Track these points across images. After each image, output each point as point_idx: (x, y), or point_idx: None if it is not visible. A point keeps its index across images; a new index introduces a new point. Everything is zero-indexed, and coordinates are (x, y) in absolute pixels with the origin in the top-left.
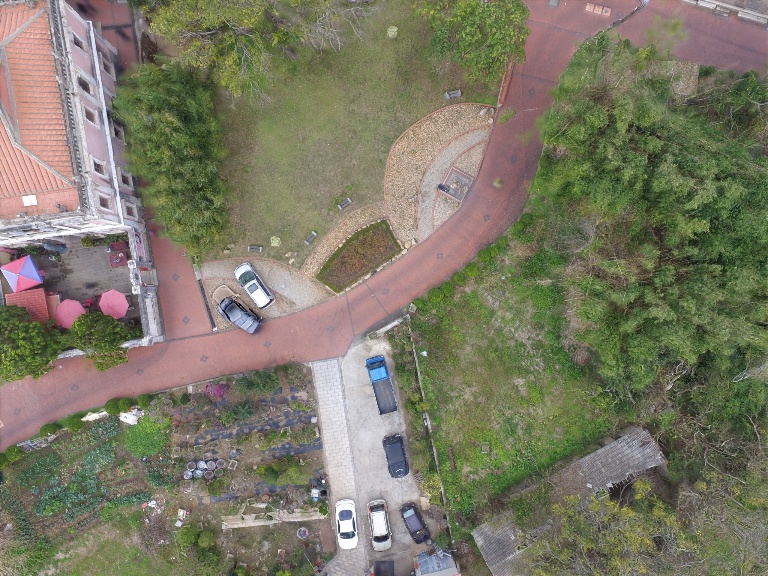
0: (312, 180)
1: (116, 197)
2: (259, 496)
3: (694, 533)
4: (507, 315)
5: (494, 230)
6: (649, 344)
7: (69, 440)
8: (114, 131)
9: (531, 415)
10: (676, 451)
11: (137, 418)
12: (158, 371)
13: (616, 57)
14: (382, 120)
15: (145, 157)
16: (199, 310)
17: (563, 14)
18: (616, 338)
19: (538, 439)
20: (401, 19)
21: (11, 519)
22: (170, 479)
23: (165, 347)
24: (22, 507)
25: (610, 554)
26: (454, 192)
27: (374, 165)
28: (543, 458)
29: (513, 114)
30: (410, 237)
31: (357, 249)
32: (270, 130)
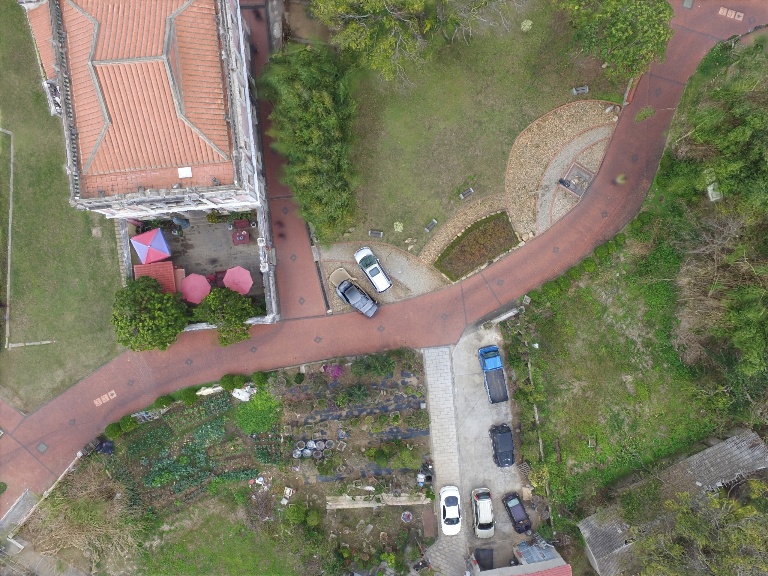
0: (435, 168)
1: (254, 174)
2: (365, 478)
3: None
4: (619, 312)
5: (611, 227)
6: None
7: (181, 413)
8: None
9: (637, 412)
10: None
11: (249, 395)
12: (272, 350)
13: (753, 61)
14: (508, 112)
15: (294, 136)
16: (315, 291)
17: (696, 17)
18: (762, 337)
19: (643, 436)
20: (533, 14)
21: (120, 488)
22: (278, 457)
23: (280, 326)
24: (131, 477)
25: (725, 551)
26: (574, 187)
27: (497, 157)
28: (647, 455)
29: (653, 112)
30: (528, 230)
31: (477, 239)
32: (397, 117)
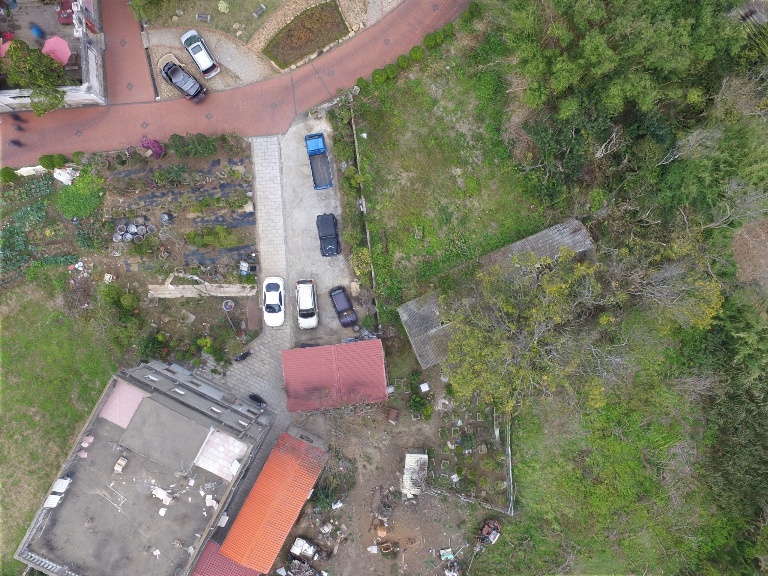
0: None
1: None
2: (188, 267)
3: (612, 289)
4: (449, 105)
5: (442, 20)
6: (571, 68)
7: (1, 195)
8: None
9: (467, 207)
10: None
11: (71, 178)
12: (97, 134)
13: None
14: None
15: None
16: (144, 78)
17: None
18: (539, 60)
19: (473, 231)
20: None
21: None
22: None
23: (106, 111)
24: None
25: (530, 317)
26: None
27: None
28: None
29: None
30: (358, 20)
31: (304, 23)
32: None
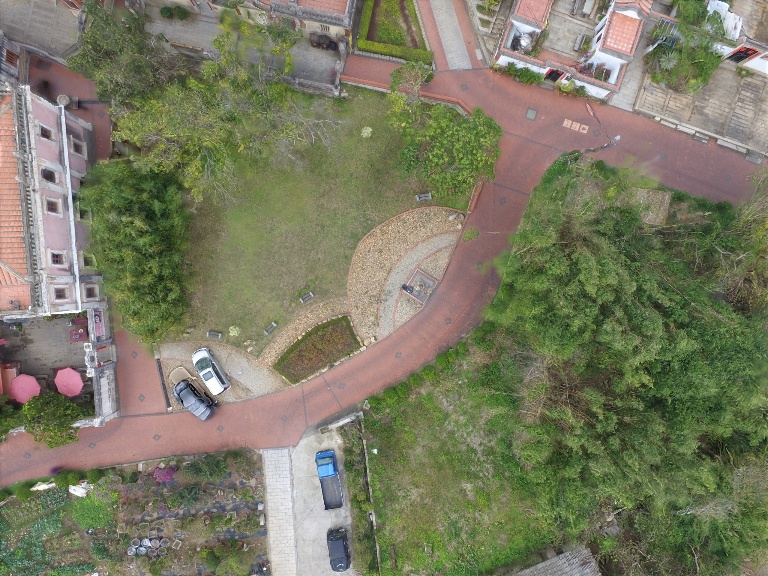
0: (276, 271)
1: (75, 283)
2: None
3: None
4: (461, 419)
5: (455, 334)
6: (585, 492)
7: (18, 506)
8: (79, 214)
9: (477, 520)
10: (615, 575)
11: (86, 491)
12: (110, 446)
13: (586, 182)
14: (351, 217)
15: (103, 254)
16: (155, 389)
17: (540, 128)
18: (552, 484)
19: (482, 544)
20: (377, 118)
21: None
22: (114, 553)
23: (119, 423)
24: None
25: None
26: (417, 293)
27: (339, 261)
28: (485, 563)
29: (476, 235)
30: (370, 334)
31: (315, 344)
32: (238, 218)
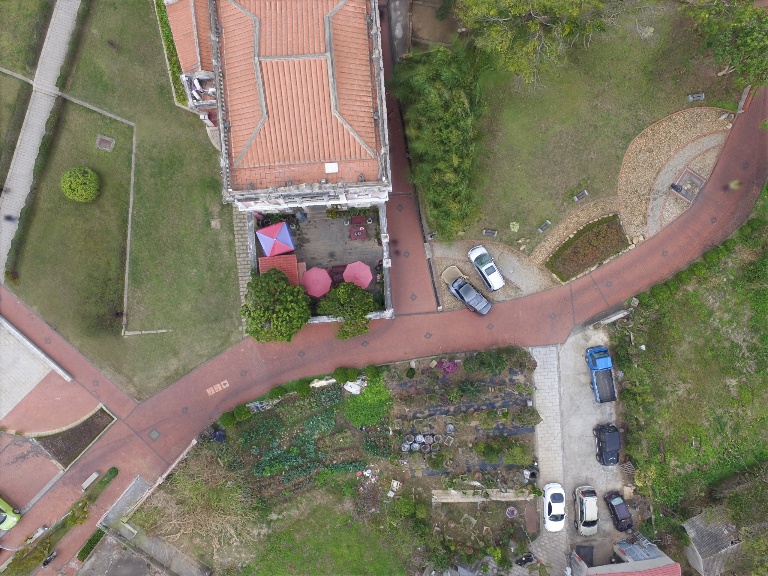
0: (550, 170)
1: None
2: (470, 473)
3: None
4: (725, 316)
5: (720, 232)
6: None
7: (292, 404)
8: None
9: (739, 415)
10: None
11: (360, 388)
12: (383, 344)
13: None
14: (623, 117)
15: (433, 135)
16: (426, 288)
17: None
18: None
19: (744, 439)
20: (652, 21)
21: (231, 477)
22: (386, 450)
23: (391, 321)
24: (242, 466)
25: None
26: (685, 193)
27: (611, 160)
28: (748, 458)
29: None
30: (638, 233)
31: (590, 240)
32: (514, 118)
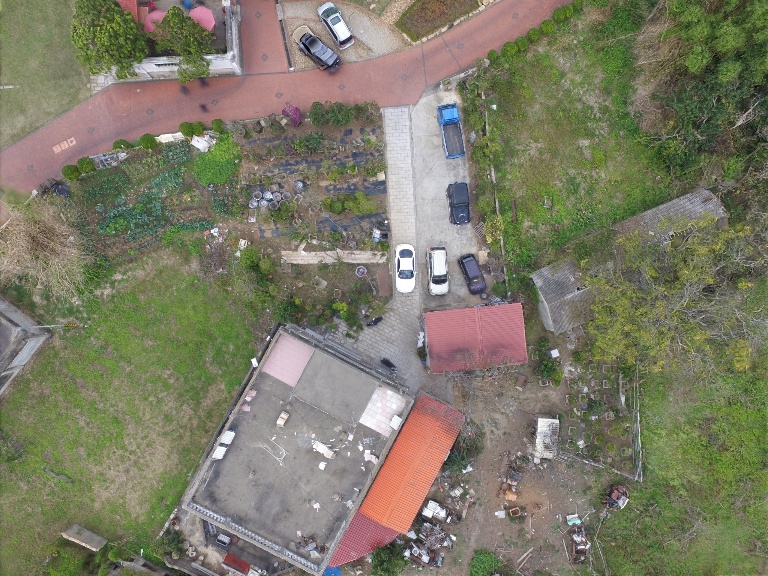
0: None
1: None
2: (321, 234)
3: (761, 253)
4: (576, 78)
5: None
6: (735, 33)
7: (139, 161)
8: None
9: (593, 178)
10: None
11: (208, 145)
12: (233, 103)
13: None
14: None
15: None
16: (278, 49)
17: None
18: (703, 25)
19: (599, 202)
20: None
21: (74, 232)
22: None
23: (242, 80)
24: (86, 223)
25: (674, 280)
26: None
27: None
28: None
29: None
30: None
31: None
32: None
